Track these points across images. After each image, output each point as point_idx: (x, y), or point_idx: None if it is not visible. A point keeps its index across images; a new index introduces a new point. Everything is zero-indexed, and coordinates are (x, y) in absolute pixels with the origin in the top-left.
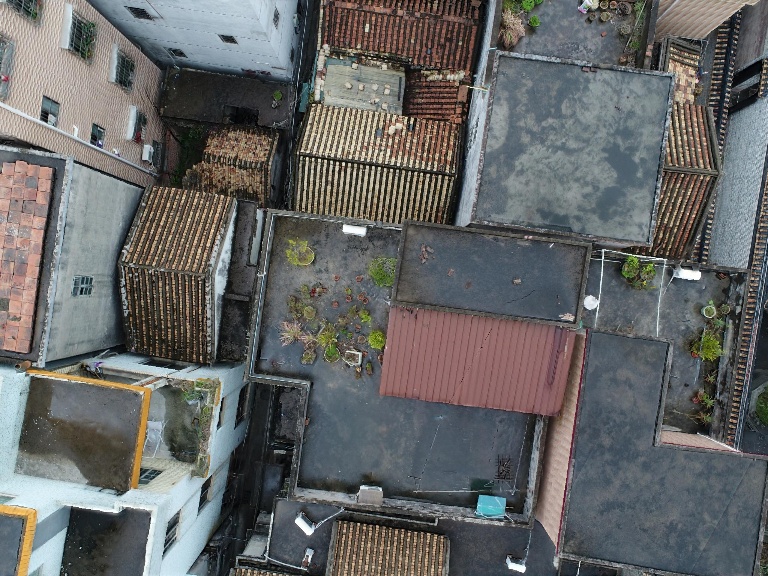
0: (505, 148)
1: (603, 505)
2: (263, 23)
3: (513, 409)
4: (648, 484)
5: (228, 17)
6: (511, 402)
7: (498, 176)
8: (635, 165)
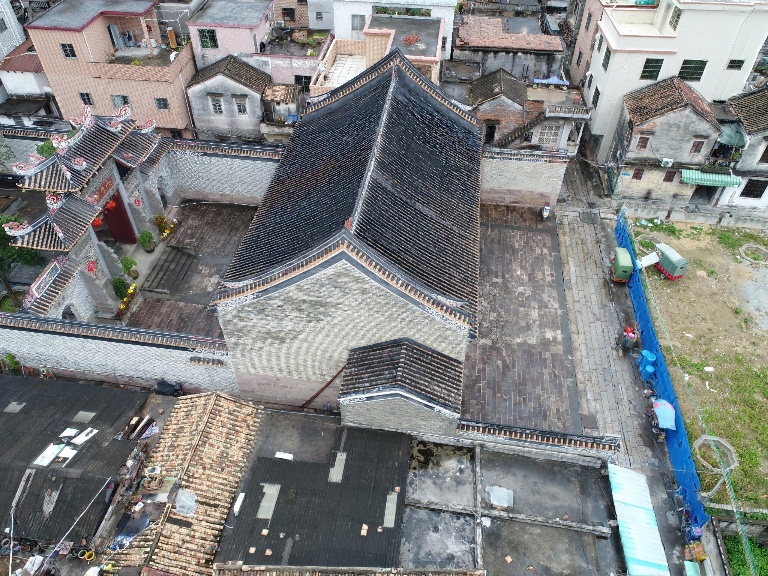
0: (237, 1)
1: None
2: None
3: None
4: None
5: None
6: None
7: (226, 0)
8: (222, 20)
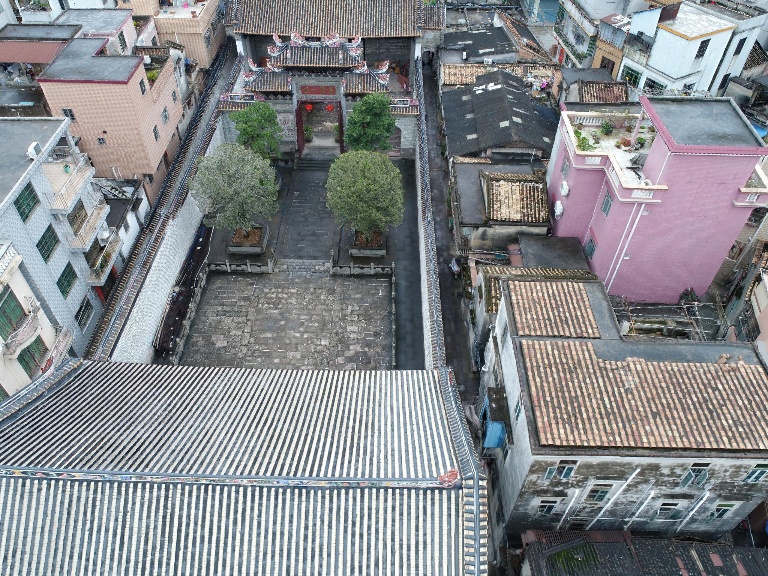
0: (62, 22)
1: None
2: None
3: (38, 63)
4: None
5: None
6: (38, 61)
7: None
8: None
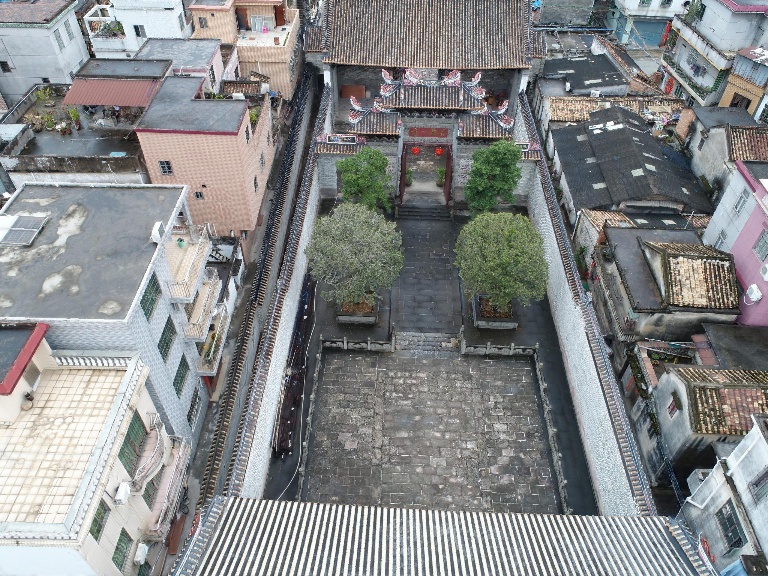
0: None
1: (162, 115)
2: (60, 62)
3: (129, 106)
4: (186, 109)
5: (44, 58)
6: (128, 103)
7: None
8: None
